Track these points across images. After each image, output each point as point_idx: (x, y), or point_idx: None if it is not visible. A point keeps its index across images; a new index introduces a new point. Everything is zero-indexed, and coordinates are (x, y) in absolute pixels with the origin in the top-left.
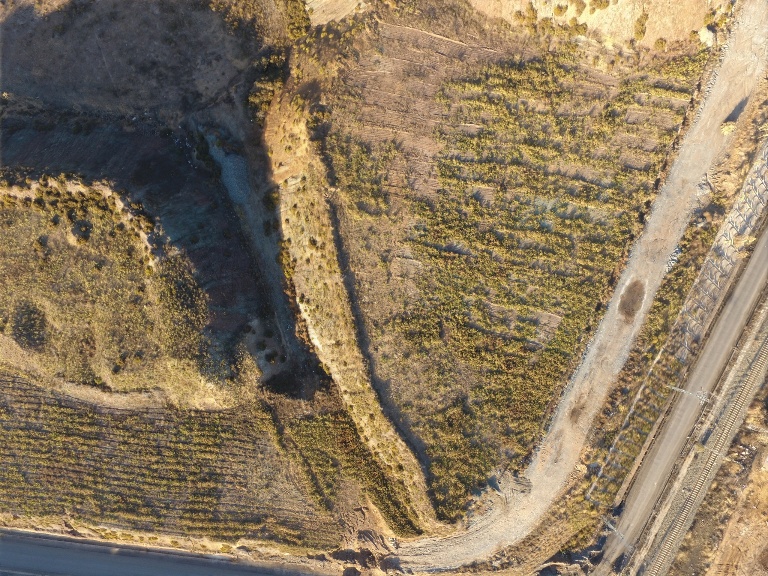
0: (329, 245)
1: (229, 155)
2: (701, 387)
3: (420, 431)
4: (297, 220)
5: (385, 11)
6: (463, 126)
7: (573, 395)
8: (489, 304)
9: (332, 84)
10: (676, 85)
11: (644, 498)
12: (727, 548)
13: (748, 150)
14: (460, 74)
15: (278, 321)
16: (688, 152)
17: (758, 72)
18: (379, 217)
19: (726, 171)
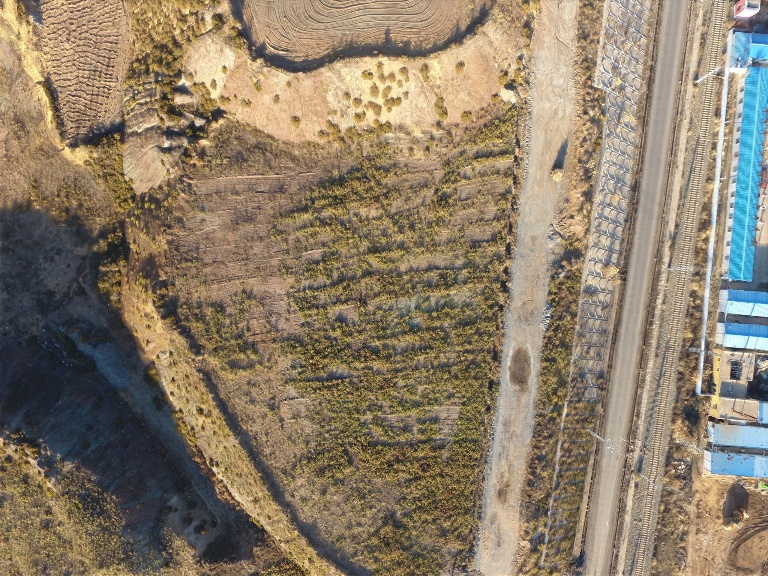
0: (214, 412)
1: (97, 346)
2: (620, 417)
3: (360, 560)
4: (179, 392)
5: (194, 170)
6: (306, 255)
7: (494, 477)
8: (386, 417)
9: (165, 258)
10: (495, 149)
11: (600, 541)
12: (694, 562)
13: (583, 190)
14: (286, 206)
15: (197, 489)
16: (528, 209)
17: (568, 112)
18: (254, 369)
19: (569, 215)
